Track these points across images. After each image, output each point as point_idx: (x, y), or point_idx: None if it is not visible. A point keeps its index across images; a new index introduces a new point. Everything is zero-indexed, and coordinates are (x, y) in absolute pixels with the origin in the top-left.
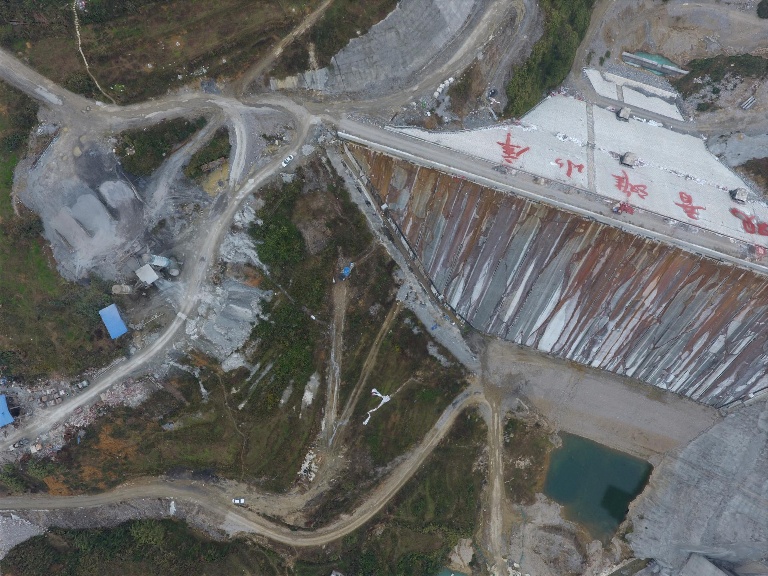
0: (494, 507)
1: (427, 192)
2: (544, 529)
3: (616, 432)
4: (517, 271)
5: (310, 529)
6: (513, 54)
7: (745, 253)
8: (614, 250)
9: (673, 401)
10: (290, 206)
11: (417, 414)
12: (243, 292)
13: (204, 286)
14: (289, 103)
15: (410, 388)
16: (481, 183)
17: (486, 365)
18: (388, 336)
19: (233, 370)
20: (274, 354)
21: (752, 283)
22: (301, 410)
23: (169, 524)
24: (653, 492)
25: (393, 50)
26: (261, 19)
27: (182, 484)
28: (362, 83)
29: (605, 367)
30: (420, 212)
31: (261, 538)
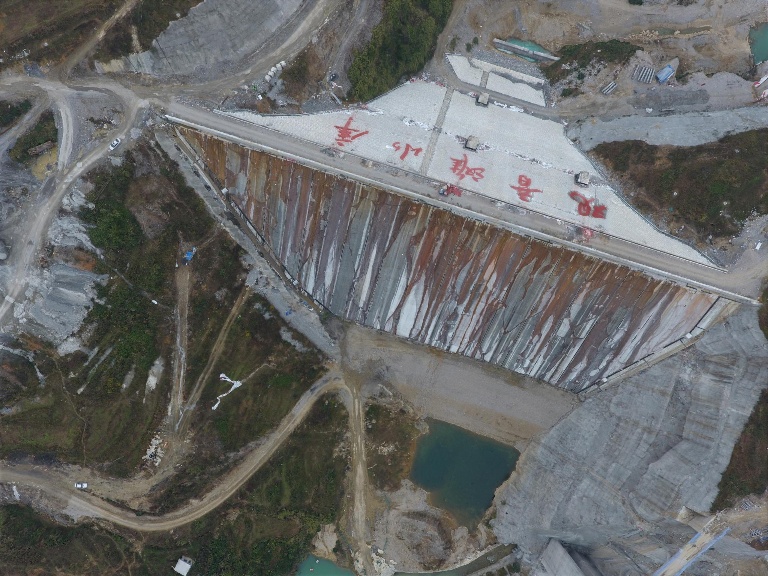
0: (357, 493)
1: (262, 176)
2: (408, 515)
3: (480, 418)
4: (362, 255)
5: (156, 514)
6: (352, 38)
7: (572, 235)
8: (448, 233)
9: (531, 386)
10: (122, 190)
11: (272, 399)
12: (74, 276)
13: (32, 270)
14: (117, 87)
15: (263, 373)
16: (311, 166)
17: (345, 351)
18: (237, 321)
19: (69, 354)
20: (112, 338)
21: (583, 265)
22: (145, 395)
23: (14, 509)
24: (518, 478)
25: (219, 33)
26: (81, 2)
27: (24, 469)
28: (191, 66)
29: (463, 352)
30: (260, 196)
31: (108, 523)
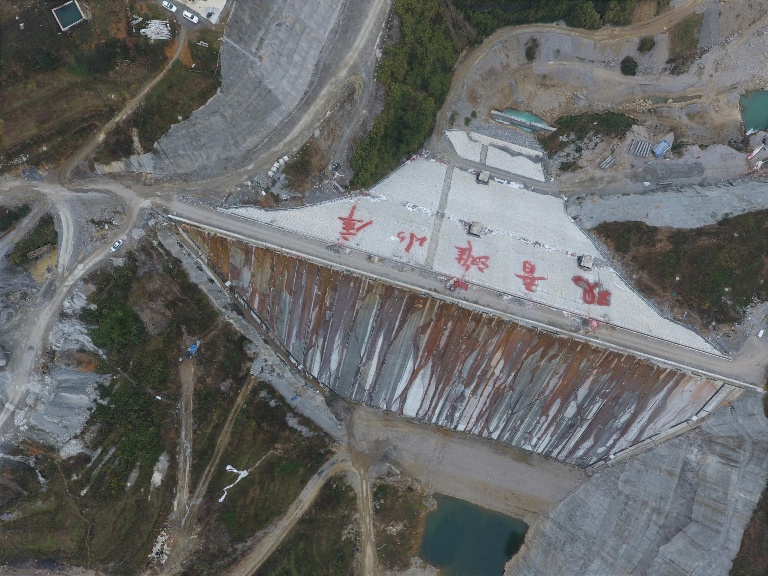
0: (367, 574)
1: (267, 270)
2: None
3: (489, 493)
4: (368, 343)
5: None
6: (354, 128)
7: (579, 326)
8: (455, 324)
9: (539, 463)
10: (124, 289)
11: (279, 486)
12: (76, 379)
13: (32, 375)
14: (117, 187)
15: (270, 461)
16: (316, 262)
17: (352, 432)
18: (242, 411)
19: (71, 457)
20: (116, 438)
21: (590, 354)
22: (150, 492)
23: None
24: (527, 552)
25: (221, 132)
26: (80, 106)
27: (26, 574)
28: (193, 164)
29: (470, 431)
30: (264, 288)
31: None
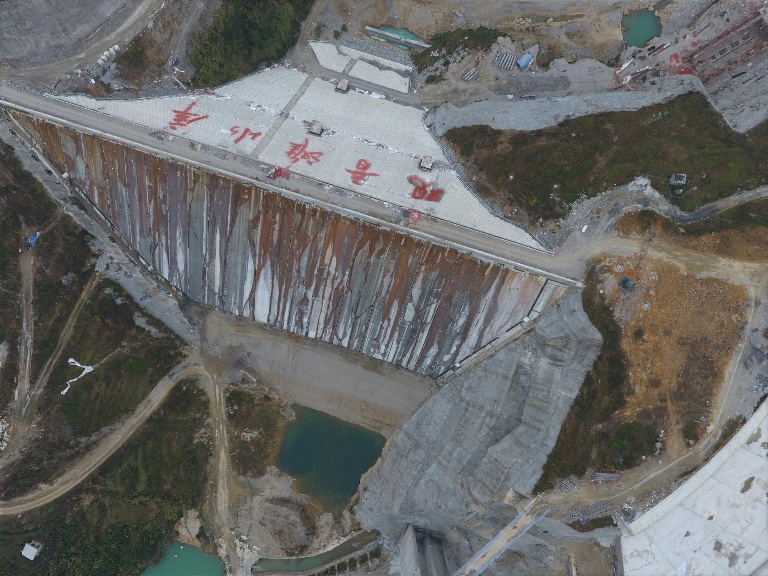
0: (220, 479)
1: (98, 160)
2: (271, 501)
3: (344, 404)
4: (207, 240)
5: (2, 498)
6: (192, 23)
7: (399, 217)
8: (282, 216)
9: (390, 372)
10: None
11: (127, 385)
12: None
13: None
14: None
15: (116, 359)
16: (142, 149)
17: (204, 337)
18: (86, 306)
19: None
20: None
21: (415, 248)
22: None
23: None
24: (381, 464)
25: (47, 17)
26: None
27: None
28: (22, 50)
29: (321, 338)
30: (100, 180)
31: None
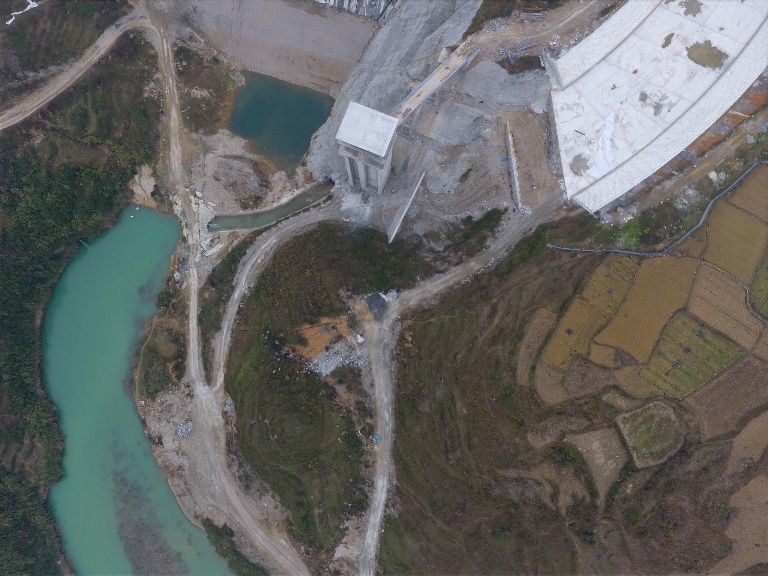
0: (173, 137)
1: None
2: (224, 157)
3: (292, 62)
4: None
5: None
6: None
7: None
8: None
9: (332, 15)
10: None
11: (73, 27)
12: None
13: None
14: None
15: None
16: None
17: None
18: None
19: None
20: None
21: None
22: None
23: None
24: None
25: None
26: None
27: None
28: None
29: None
30: None
31: None
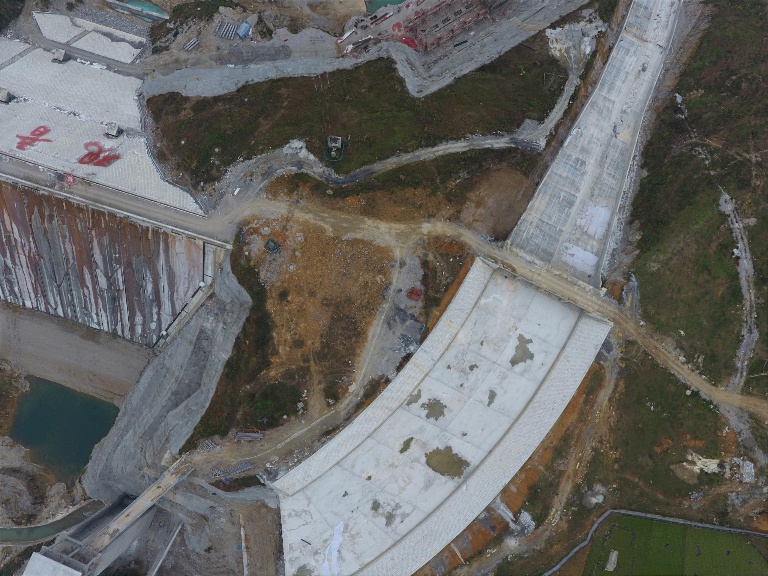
0: None
1: None
2: None
3: (74, 374)
4: None
5: None
6: None
7: (54, 181)
8: None
9: (106, 341)
10: None
11: None
12: None
13: None
14: None
15: None
16: None
17: None
18: None
19: None
20: None
21: (78, 213)
22: None
23: None
24: None
25: None
26: None
27: None
28: None
29: (38, 308)
30: None
31: None
